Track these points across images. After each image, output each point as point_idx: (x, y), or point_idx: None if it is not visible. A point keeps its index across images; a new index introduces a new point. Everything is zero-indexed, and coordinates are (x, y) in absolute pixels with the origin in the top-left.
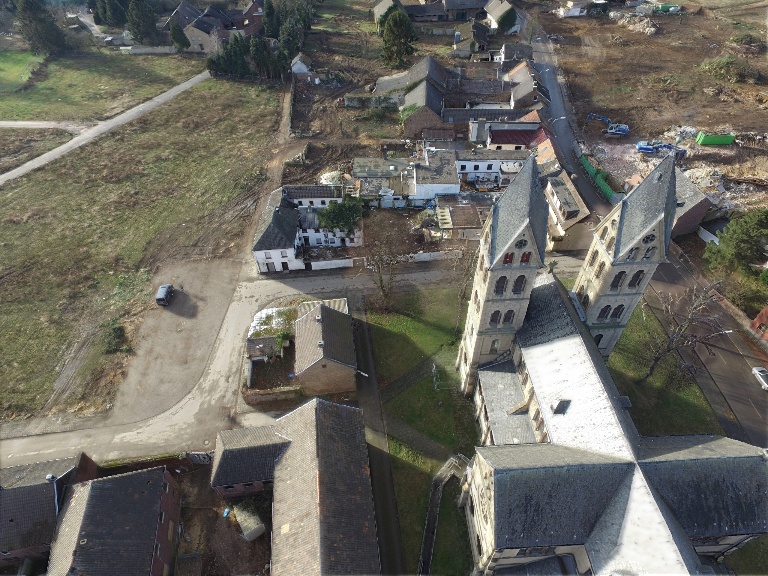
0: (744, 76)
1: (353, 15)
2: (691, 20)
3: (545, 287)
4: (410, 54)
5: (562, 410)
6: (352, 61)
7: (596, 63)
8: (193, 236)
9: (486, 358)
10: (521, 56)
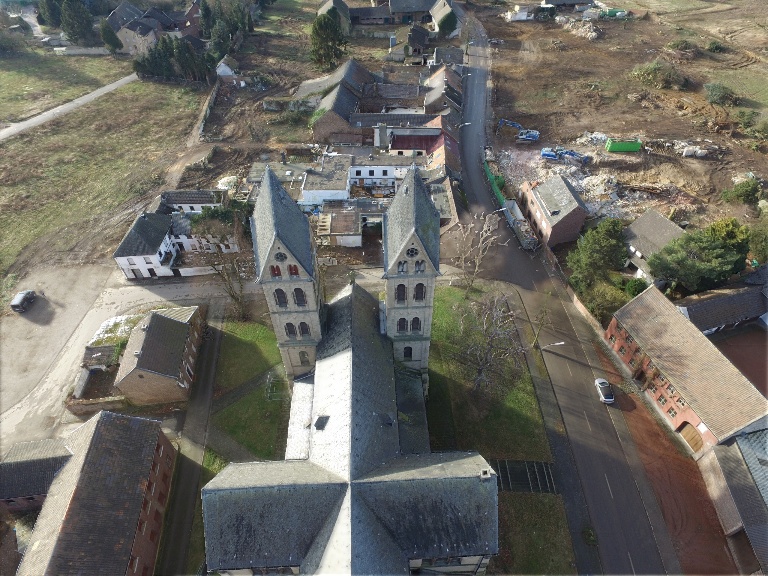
0: (670, 82)
1: (300, 17)
2: (636, 25)
3: (345, 299)
4: (338, 57)
5: (322, 426)
6: (285, 64)
7: (529, 68)
8: (72, 241)
9: (301, 370)
10: (452, 60)
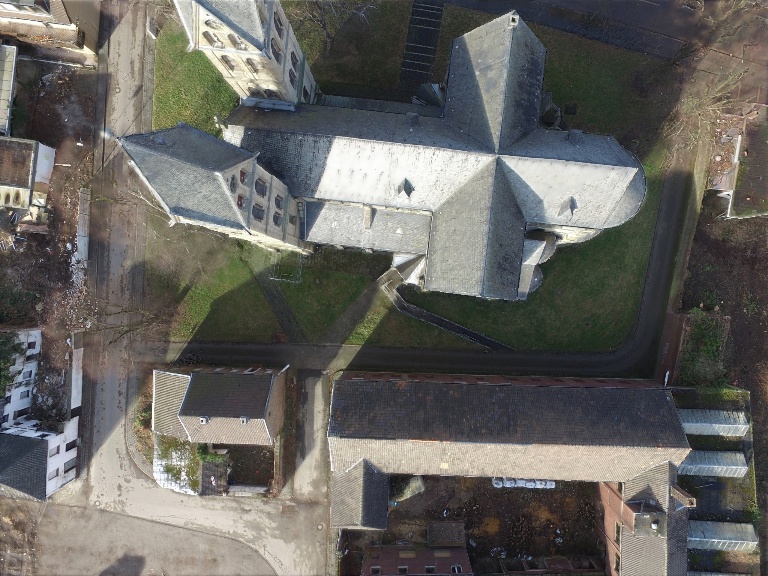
0: None
1: None
2: None
3: (246, 141)
4: None
5: (410, 190)
6: None
7: None
8: None
9: (297, 229)
10: None
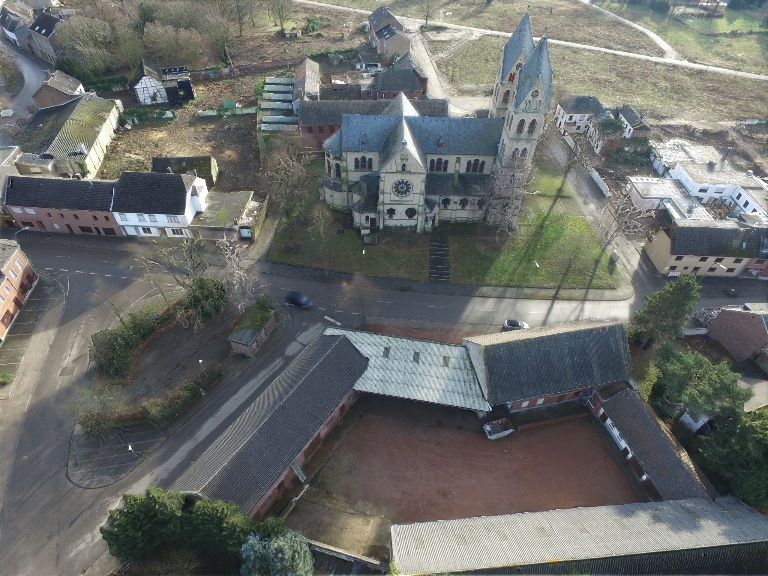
0: None
1: None
2: None
3: None
4: None
5: None
6: None
7: None
8: None
9: None
10: None
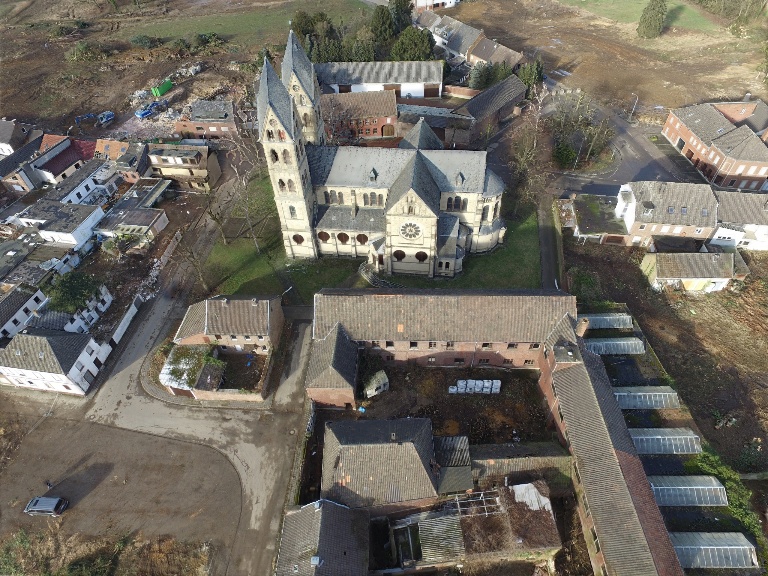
0: (107, 51)
1: None
2: None
3: None
4: None
5: (376, 175)
6: None
7: None
8: None
9: (311, 218)
10: None
